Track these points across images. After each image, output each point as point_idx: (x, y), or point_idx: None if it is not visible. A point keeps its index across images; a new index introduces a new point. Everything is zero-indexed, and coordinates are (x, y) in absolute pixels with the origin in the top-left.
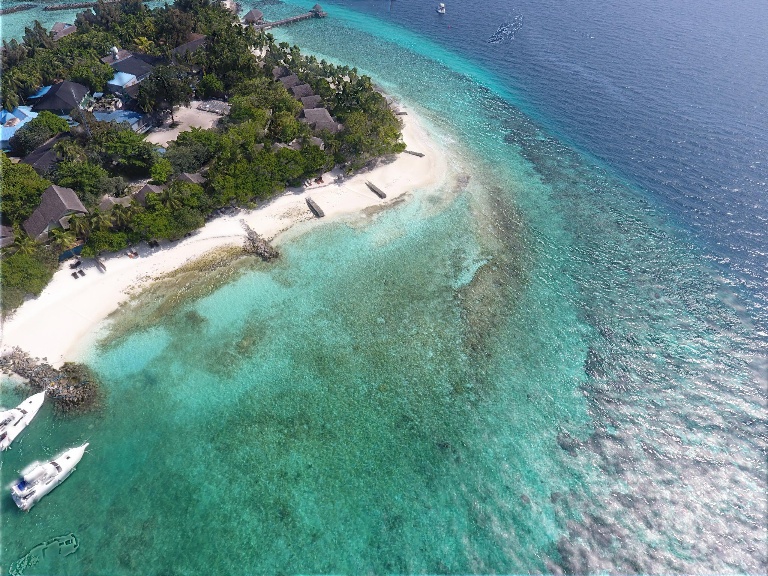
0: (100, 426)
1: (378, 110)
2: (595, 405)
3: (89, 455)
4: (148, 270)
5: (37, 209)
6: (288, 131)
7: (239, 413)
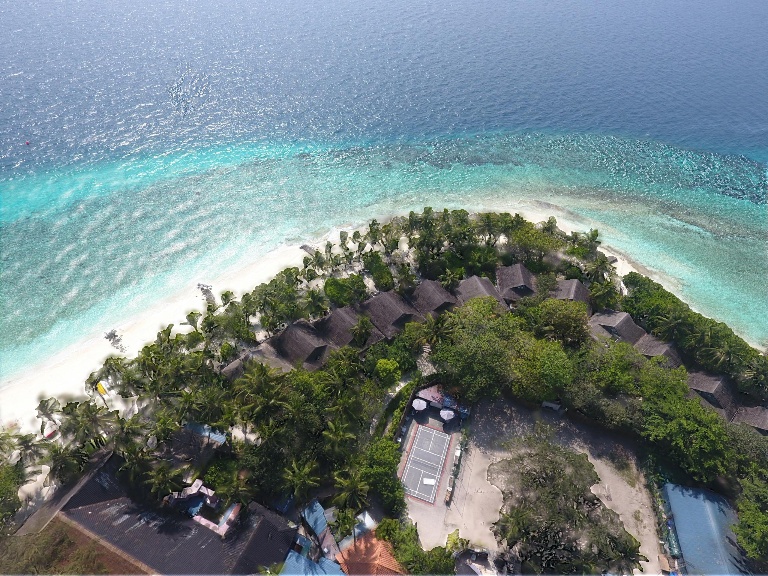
0: None
1: None
2: (766, 202)
3: None
4: None
5: None
6: None
7: None
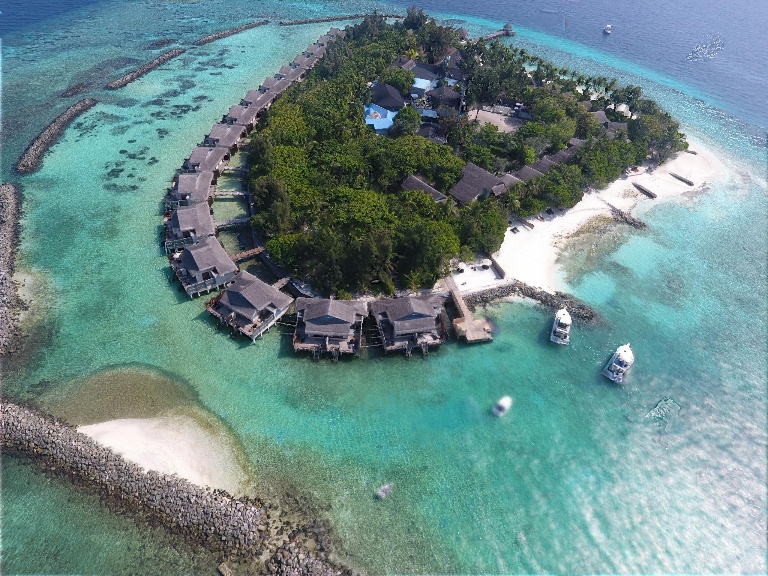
0: (616, 335)
1: None
2: None
3: (633, 351)
4: (557, 231)
5: (461, 180)
6: (593, 129)
7: (709, 333)
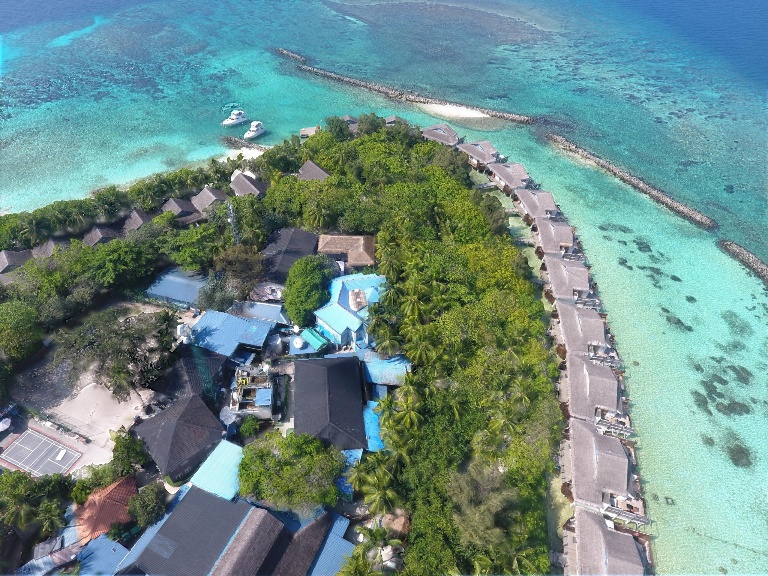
0: None
1: None
2: None
3: None
4: None
5: None
6: None
7: None
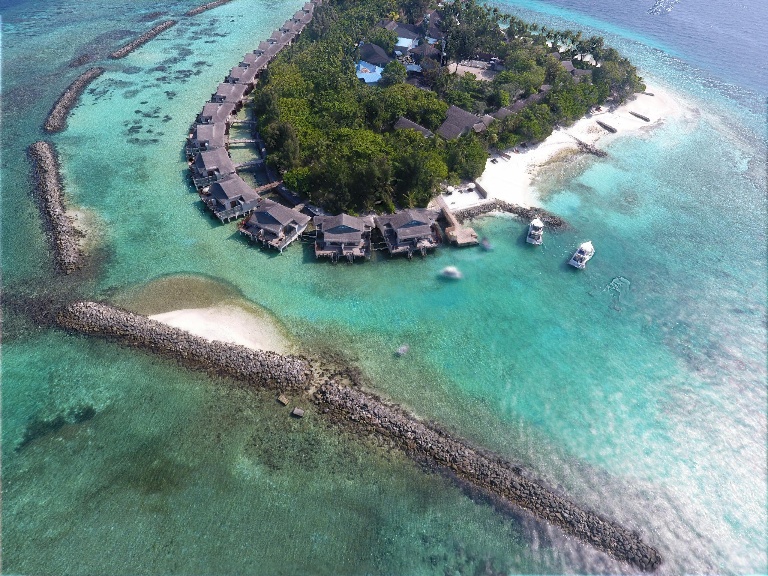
0: (581, 237)
1: None
2: None
3: None
4: (531, 161)
5: (446, 121)
6: (561, 76)
7: (657, 233)
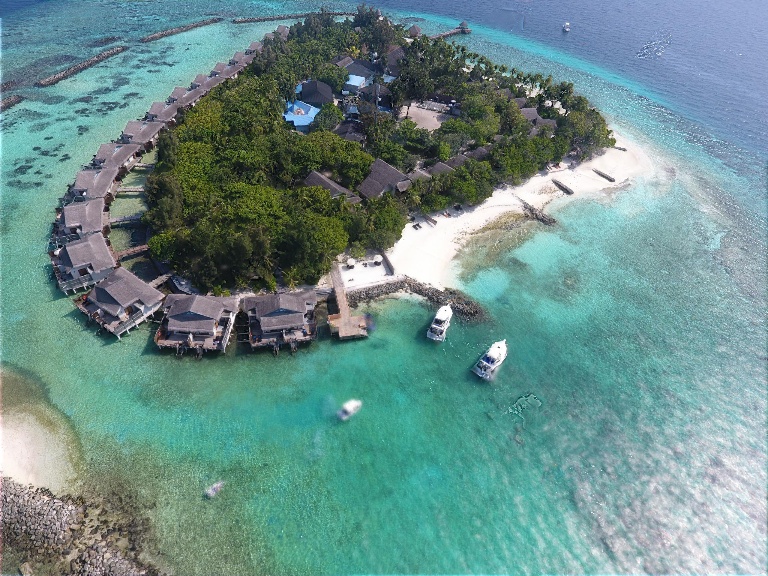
0: (498, 331)
1: (594, 110)
2: None
3: (509, 347)
4: (462, 227)
5: (369, 177)
6: (519, 125)
7: (594, 329)
